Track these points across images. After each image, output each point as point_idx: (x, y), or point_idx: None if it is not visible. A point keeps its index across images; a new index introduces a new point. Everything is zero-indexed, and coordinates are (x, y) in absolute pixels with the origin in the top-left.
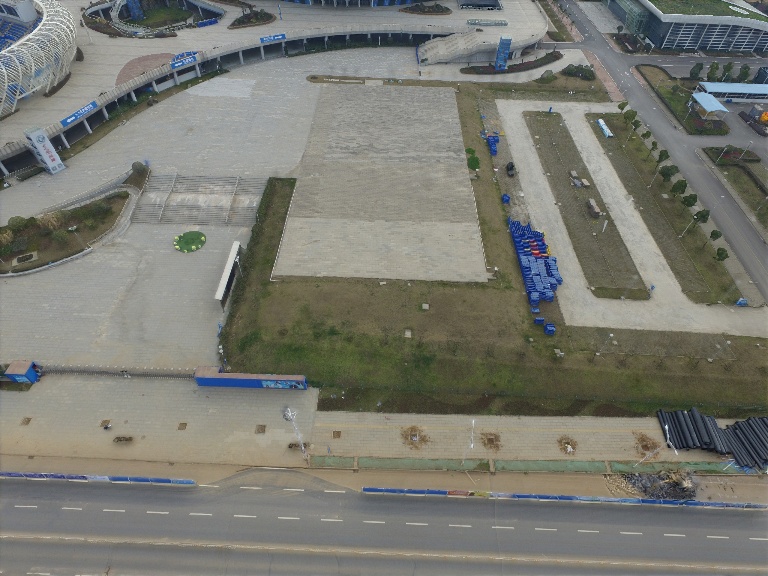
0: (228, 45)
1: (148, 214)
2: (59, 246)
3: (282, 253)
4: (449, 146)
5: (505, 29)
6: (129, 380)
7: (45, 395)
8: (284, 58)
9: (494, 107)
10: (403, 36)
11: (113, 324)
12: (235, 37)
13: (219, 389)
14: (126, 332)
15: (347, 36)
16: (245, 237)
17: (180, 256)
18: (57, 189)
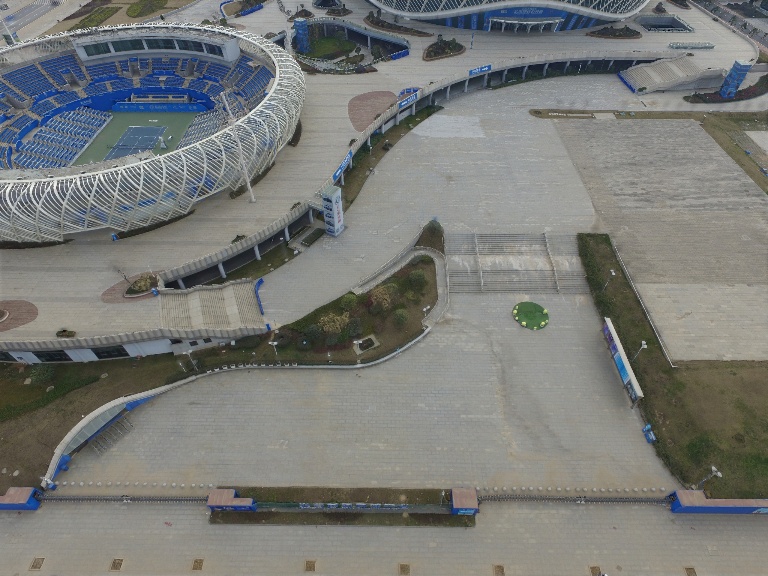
0: (442, 80)
1: (463, 282)
2: (394, 327)
3: (661, 330)
4: (745, 189)
5: (714, 52)
6: (585, 507)
7: (499, 532)
8: (489, 91)
9: (750, 140)
10: (603, 63)
11: (515, 428)
12: (439, 70)
13: (699, 517)
14: (537, 439)
15: (546, 65)
16: (588, 308)
17: (532, 335)
18: (353, 255)
